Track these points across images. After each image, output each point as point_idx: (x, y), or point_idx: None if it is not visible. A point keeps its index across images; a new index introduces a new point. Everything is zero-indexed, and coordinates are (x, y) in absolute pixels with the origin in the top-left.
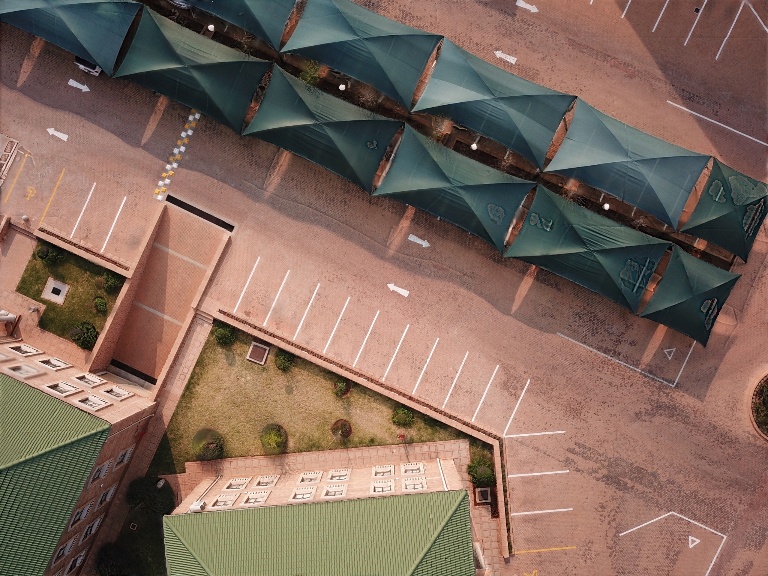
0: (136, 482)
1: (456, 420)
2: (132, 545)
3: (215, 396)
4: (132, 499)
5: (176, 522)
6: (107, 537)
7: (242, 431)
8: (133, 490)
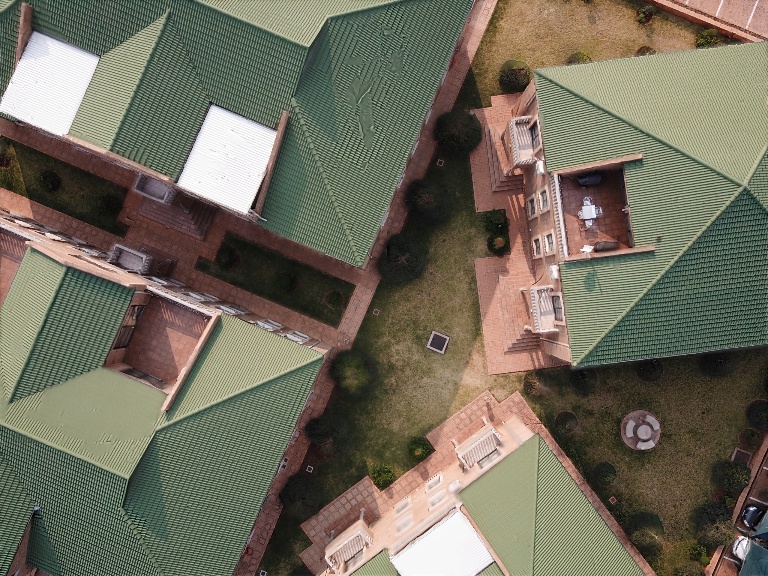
0: (445, 114)
1: (760, 39)
2: (440, 181)
3: (519, 29)
4: (441, 132)
5: (549, 73)
6: (414, 174)
7: (546, 63)
8: (443, 122)
